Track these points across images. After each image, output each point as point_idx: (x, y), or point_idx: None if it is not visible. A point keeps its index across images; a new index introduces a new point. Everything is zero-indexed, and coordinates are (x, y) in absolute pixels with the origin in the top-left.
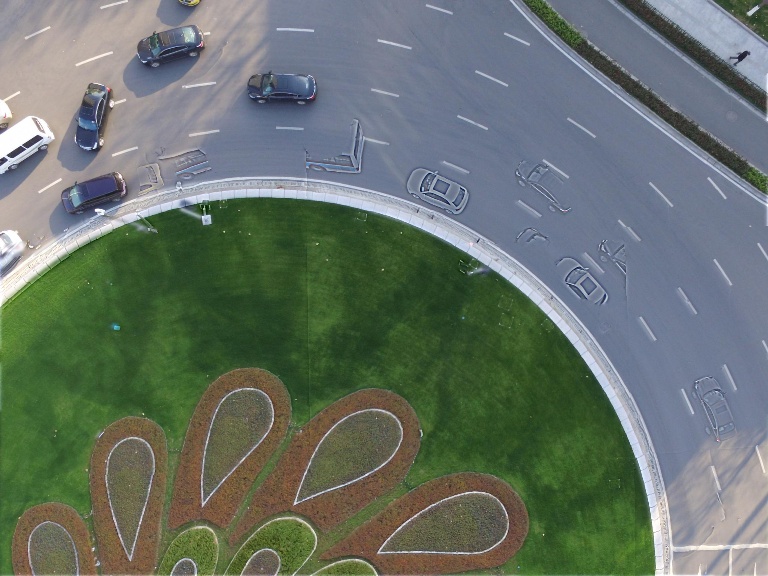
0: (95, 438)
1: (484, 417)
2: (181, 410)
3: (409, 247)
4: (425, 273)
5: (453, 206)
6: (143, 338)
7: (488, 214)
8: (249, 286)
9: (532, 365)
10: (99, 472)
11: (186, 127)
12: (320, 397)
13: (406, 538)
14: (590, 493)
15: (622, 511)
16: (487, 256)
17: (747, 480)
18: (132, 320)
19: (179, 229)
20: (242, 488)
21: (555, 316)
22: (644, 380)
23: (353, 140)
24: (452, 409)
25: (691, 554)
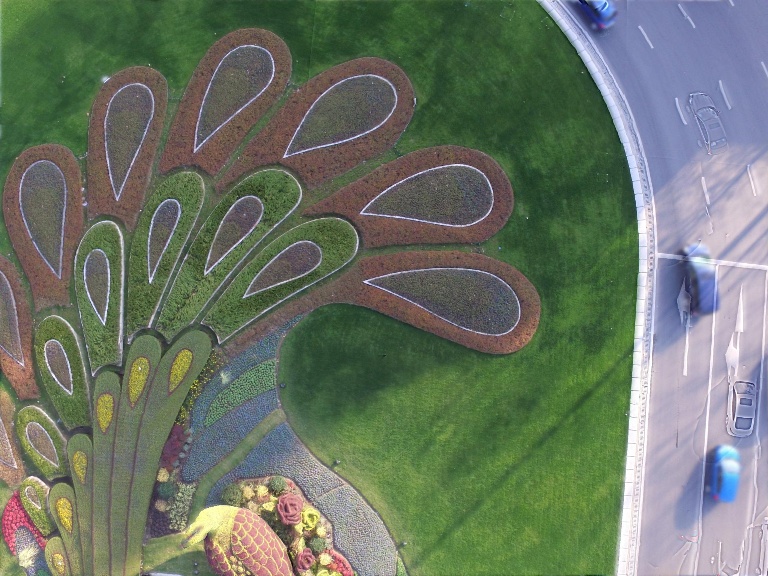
0: (100, 85)
1: (478, 96)
2: (186, 63)
3: None
4: None
5: None
6: None
7: None
8: None
9: (529, 55)
10: (99, 113)
11: None
12: (320, 61)
13: (390, 201)
14: (577, 183)
15: (608, 205)
16: None
17: (737, 197)
18: None
19: None
20: (235, 136)
21: (555, 15)
22: (639, 84)
23: None
24: (447, 85)
25: (676, 264)
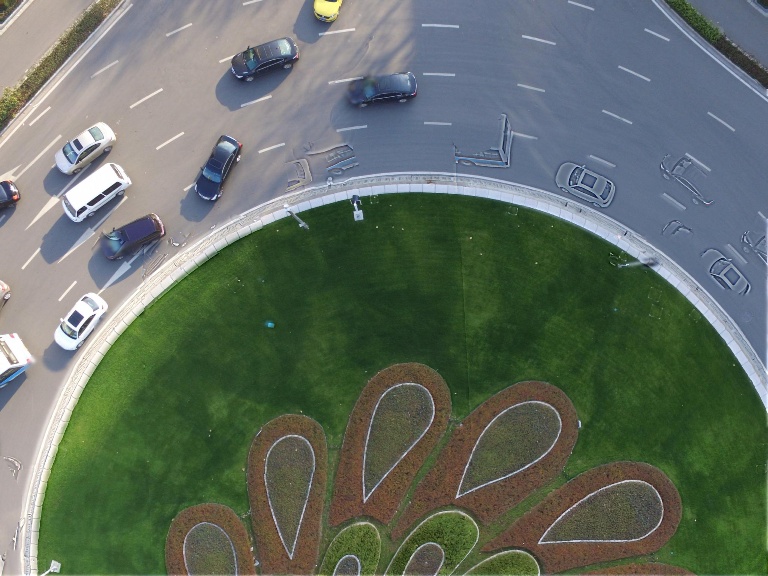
0: (251, 437)
1: (638, 407)
2: (340, 406)
3: (560, 240)
4: (576, 266)
5: (601, 199)
6: (298, 335)
7: (635, 207)
8: (405, 281)
9: (682, 355)
10: (258, 471)
11: (334, 122)
12: (479, 390)
13: (566, 528)
14: (739, 478)
15: None
16: (635, 248)
17: None
18: (287, 317)
19: (331, 225)
20: (405, 483)
21: (702, 306)
22: None
23: (501, 135)
24: (607, 399)
25: None
